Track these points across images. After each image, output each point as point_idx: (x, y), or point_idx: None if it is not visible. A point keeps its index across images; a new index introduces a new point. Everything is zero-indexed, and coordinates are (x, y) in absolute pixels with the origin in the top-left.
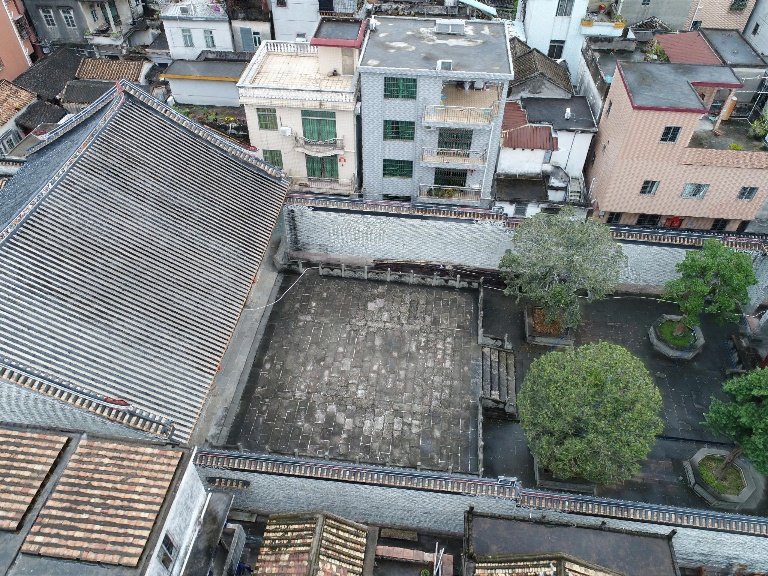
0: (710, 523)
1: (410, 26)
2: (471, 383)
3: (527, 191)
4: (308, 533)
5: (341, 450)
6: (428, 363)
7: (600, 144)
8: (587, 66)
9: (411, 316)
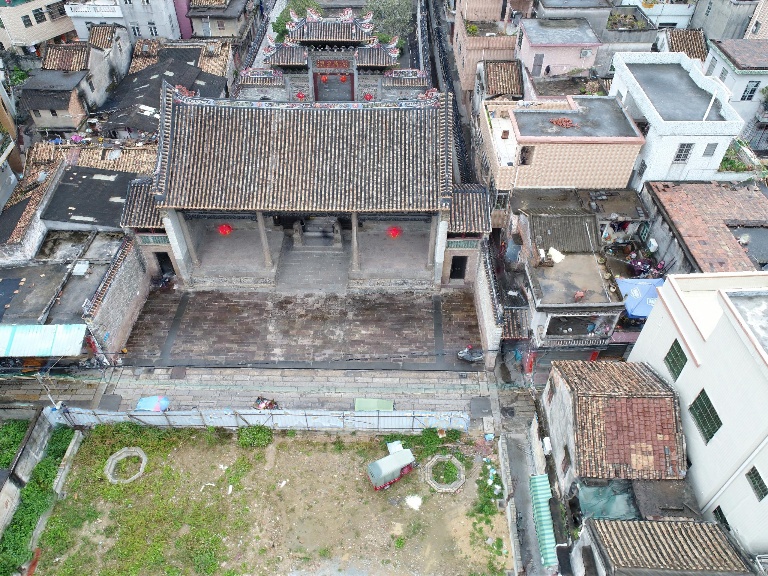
0: None
1: None
2: None
3: None
4: None
5: None
6: None
7: None
8: None
9: None
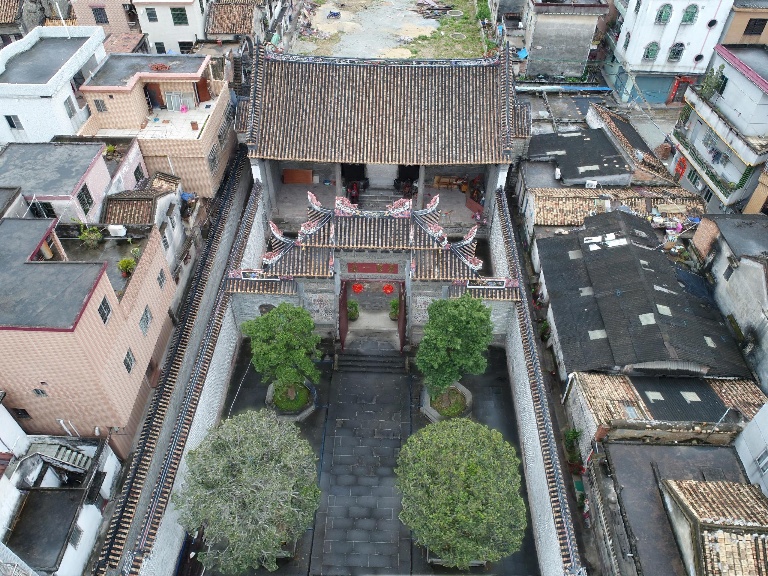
0: (547, 415)
1: None
2: None
3: (50, 518)
4: None
5: None
6: None
7: (19, 396)
8: None
9: None
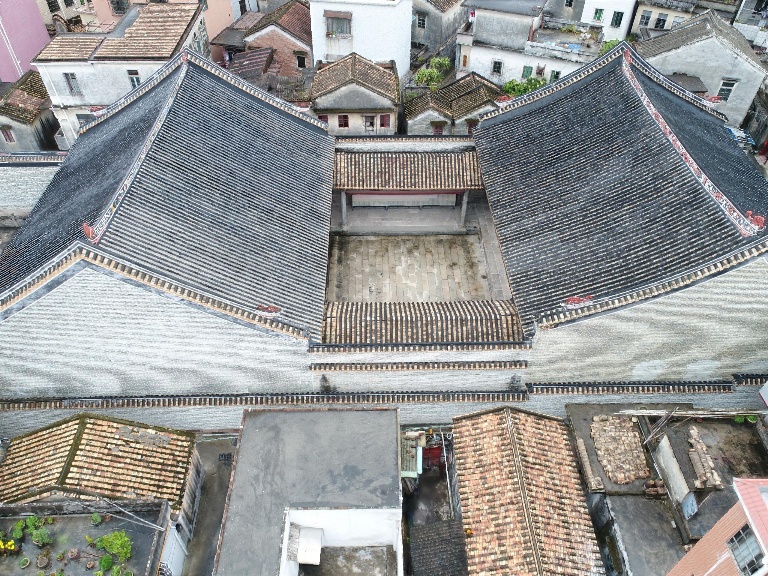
0: None
1: None
2: None
3: None
4: (6, 109)
5: (5, 235)
6: None
7: None
8: None
9: None
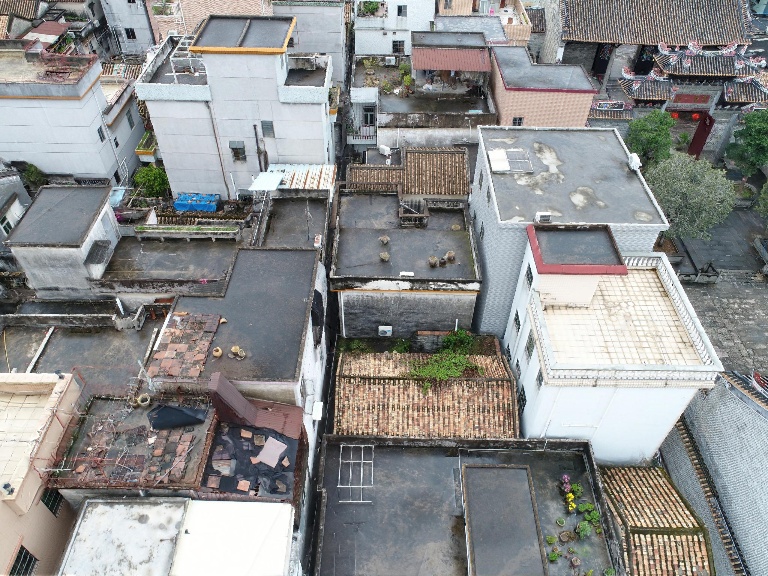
0: None
1: (517, 192)
2: (759, 288)
3: None
4: None
5: None
6: (760, 313)
7: None
8: (416, 128)
9: (715, 325)
